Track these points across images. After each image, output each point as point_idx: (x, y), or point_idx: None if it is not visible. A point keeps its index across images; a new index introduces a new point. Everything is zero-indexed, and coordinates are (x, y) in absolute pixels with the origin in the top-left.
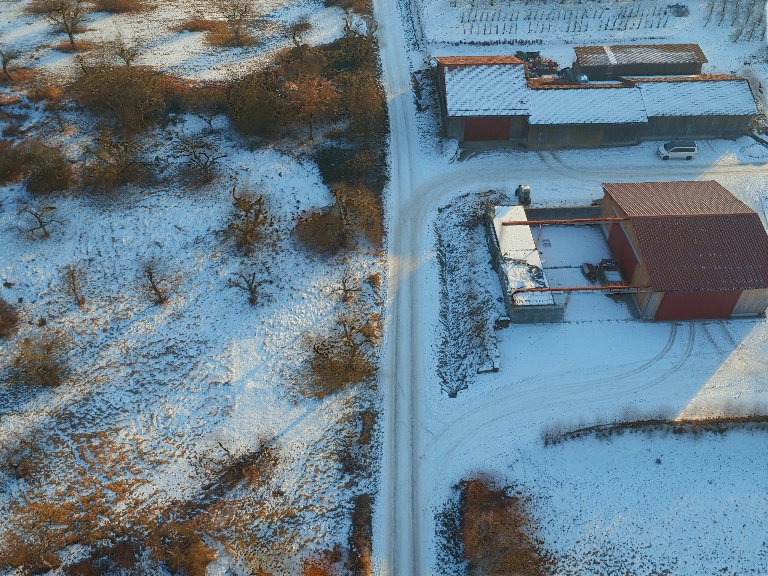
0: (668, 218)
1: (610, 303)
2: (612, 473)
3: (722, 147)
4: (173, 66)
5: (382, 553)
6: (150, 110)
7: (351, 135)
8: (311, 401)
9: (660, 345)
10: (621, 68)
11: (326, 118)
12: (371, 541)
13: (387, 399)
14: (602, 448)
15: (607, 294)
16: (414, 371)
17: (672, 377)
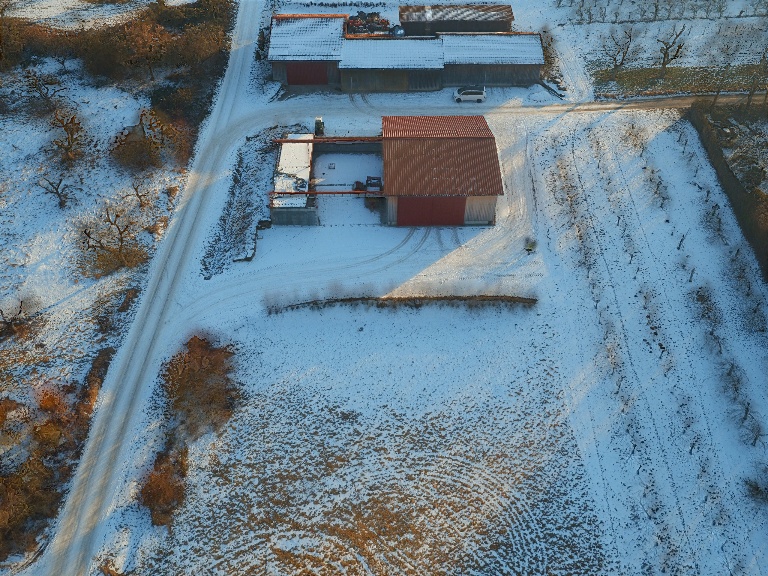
0: (416, 139)
1: (366, 212)
2: (320, 337)
3: (513, 93)
4: (47, 18)
5: (109, 388)
6: (12, 52)
7: (189, 77)
8: (89, 280)
9: (394, 244)
10: (437, 25)
11: (171, 63)
12: (103, 380)
13: (152, 280)
14: (316, 318)
15: (366, 205)
16: (182, 260)
17: (394, 267)
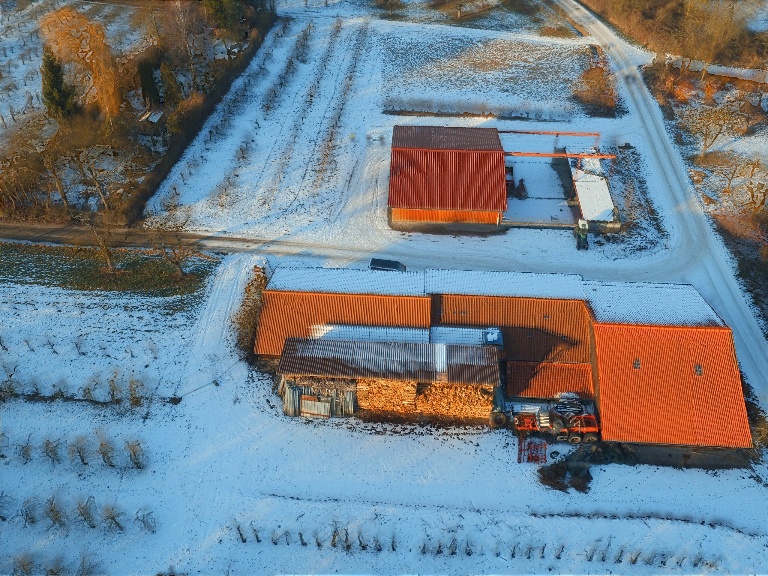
0: None
1: None
2: None
3: None
4: None
5: (654, 105)
6: None
7: None
8: None
9: None
10: None
11: None
12: None
13: (671, 147)
14: None
15: None
16: (657, 157)
17: None
